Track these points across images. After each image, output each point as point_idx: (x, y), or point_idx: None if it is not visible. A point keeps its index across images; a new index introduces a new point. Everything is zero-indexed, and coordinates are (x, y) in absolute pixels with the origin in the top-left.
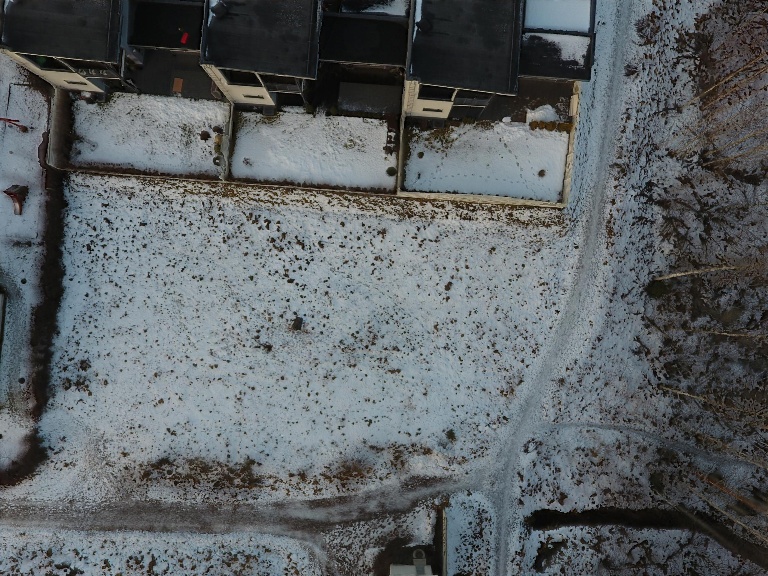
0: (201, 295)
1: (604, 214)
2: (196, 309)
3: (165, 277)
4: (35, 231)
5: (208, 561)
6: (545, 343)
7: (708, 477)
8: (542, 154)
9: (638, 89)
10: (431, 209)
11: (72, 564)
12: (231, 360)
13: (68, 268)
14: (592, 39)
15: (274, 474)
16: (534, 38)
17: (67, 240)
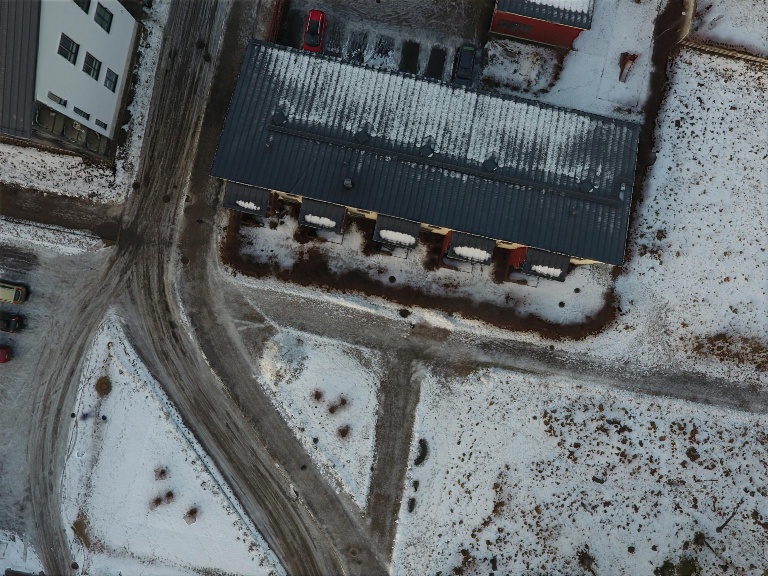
0: None
1: None
2: None
3: (746, 162)
4: (636, 100)
5: (743, 437)
6: None
7: None
8: None
9: None
10: None
11: (622, 421)
12: None
13: (657, 140)
14: None
15: None
16: None
17: (660, 113)
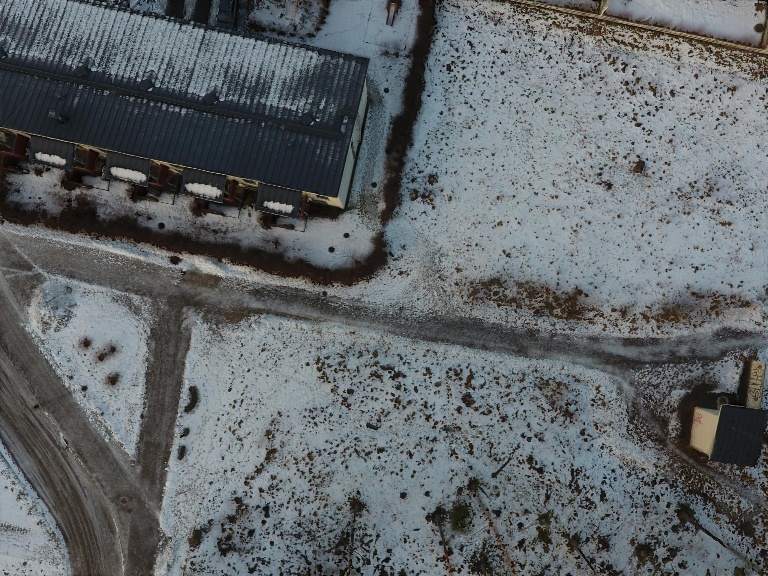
0: (550, 127)
1: None
2: (544, 140)
3: (518, 106)
4: (404, 43)
5: (521, 383)
6: None
7: None
8: None
9: None
10: None
11: (396, 367)
12: (572, 193)
13: (427, 84)
14: None
15: (598, 307)
16: None
17: (430, 57)
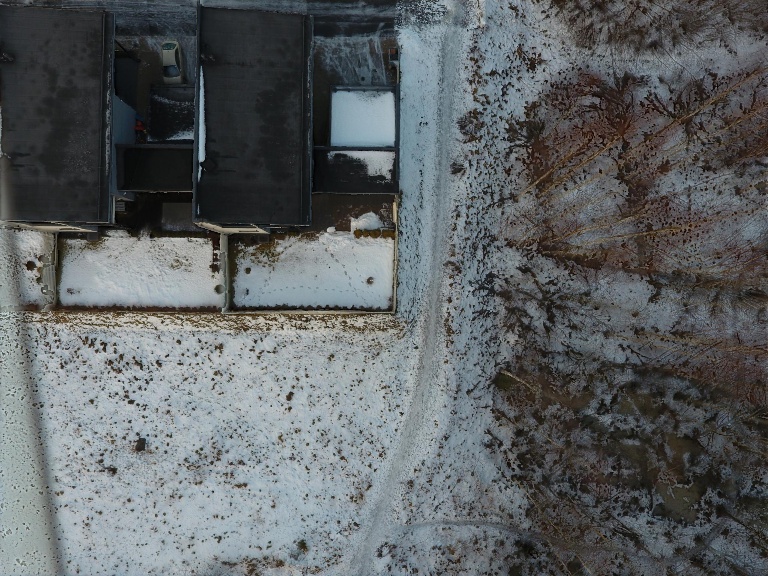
0: (43, 422)
1: (441, 313)
2: (38, 437)
3: (5, 407)
4: None
5: None
6: (391, 446)
7: (568, 566)
8: (369, 261)
9: (466, 186)
10: (264, 322)
11: None
12: (76, 486)
13: None
14: (396, 154)
15: None
16: (339, 156)
17: None
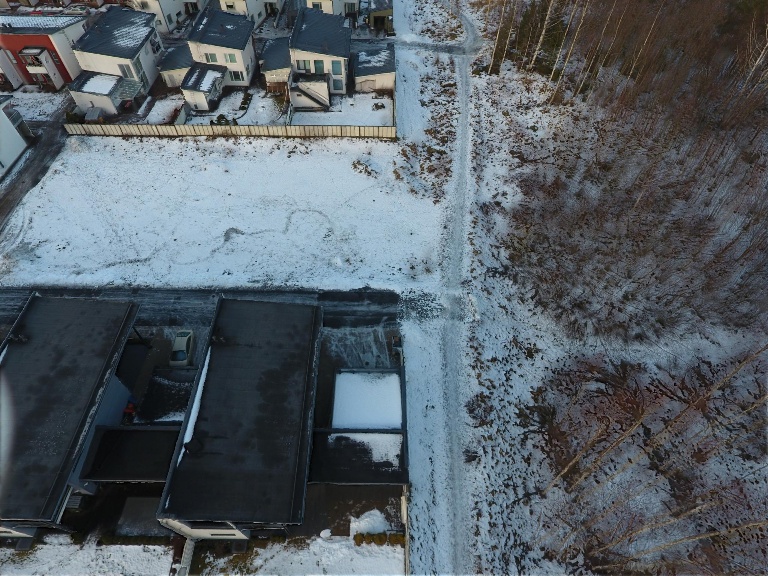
0: None
1: None
2: None
3: None
4: None
5: None
6: None
7: None
8: None
9: (484, 476)
10: None
11: None
12: None
13: None
14: (404, 436)
15: None
16: (341, 439)
17: None
